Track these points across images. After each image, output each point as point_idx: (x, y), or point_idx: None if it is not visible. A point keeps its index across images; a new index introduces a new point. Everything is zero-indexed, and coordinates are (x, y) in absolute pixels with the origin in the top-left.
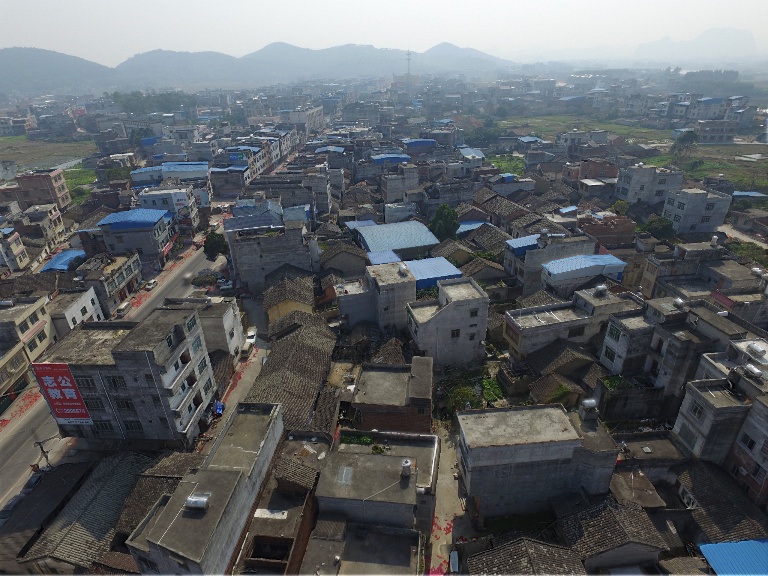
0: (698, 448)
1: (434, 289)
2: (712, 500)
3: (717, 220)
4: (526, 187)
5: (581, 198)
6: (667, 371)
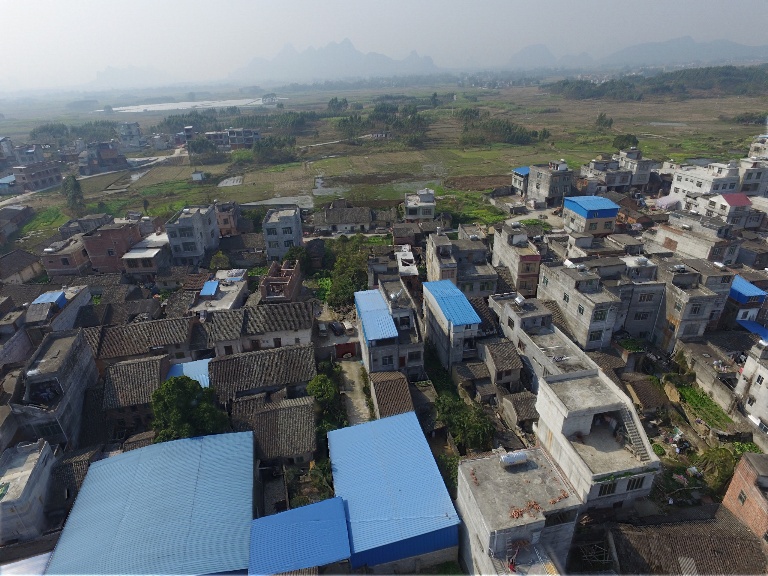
0: (703, 329)
1: (448, 459)
2: (737, 344)
3: (301, 232)
4: (83, 300)
5: (134, 279)
6: (624, 313)
